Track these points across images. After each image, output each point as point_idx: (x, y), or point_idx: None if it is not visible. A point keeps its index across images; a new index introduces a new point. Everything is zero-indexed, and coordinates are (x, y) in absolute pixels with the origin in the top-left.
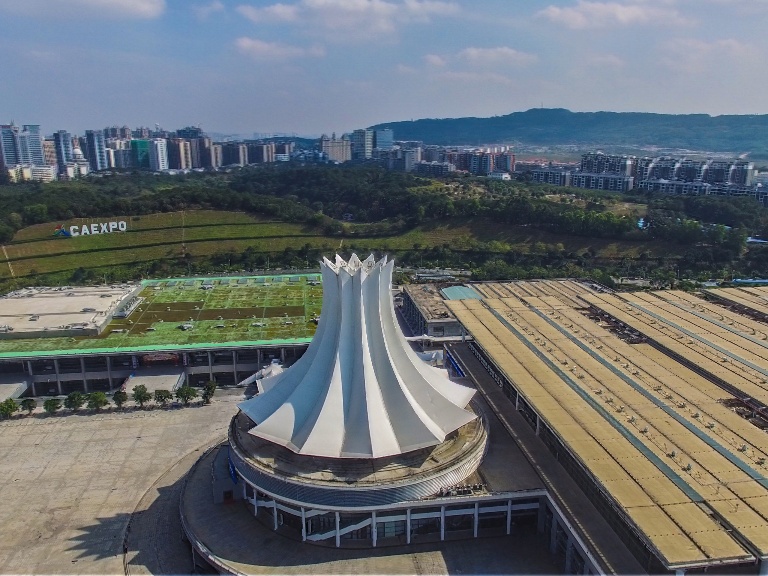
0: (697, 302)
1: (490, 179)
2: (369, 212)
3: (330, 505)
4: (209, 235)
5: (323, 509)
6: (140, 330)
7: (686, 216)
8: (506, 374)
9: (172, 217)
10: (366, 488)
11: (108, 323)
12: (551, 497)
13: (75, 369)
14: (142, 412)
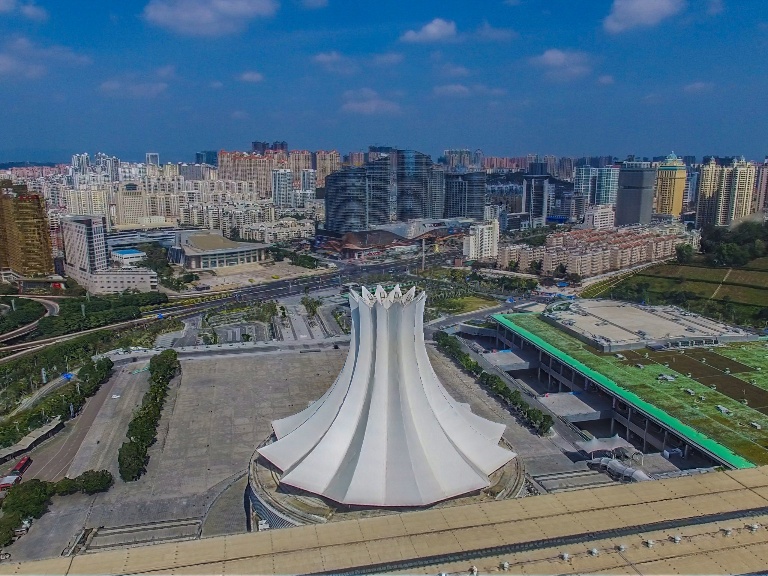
0: None
1: None
2: None
3: None
4: None
5: None
6: (633, 363)
7: None
8: None
9: None
10: None
11: (632, 348)
12: None
13: None
14: (506, 412)
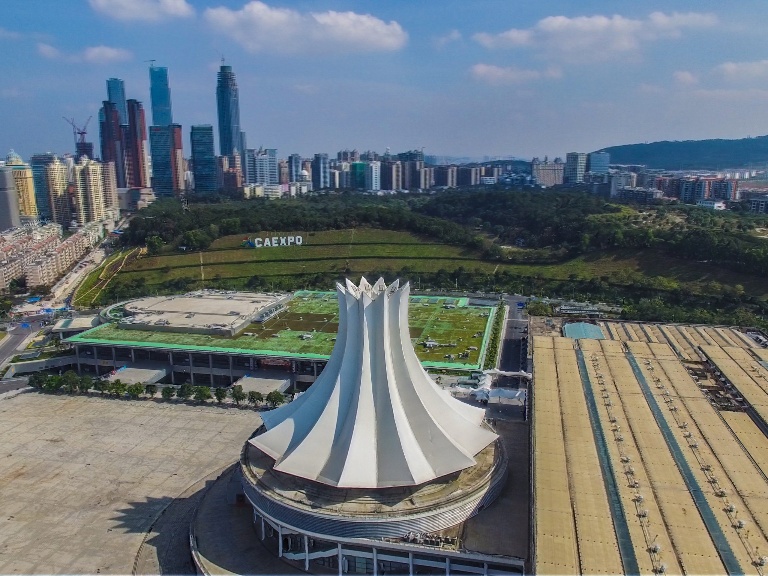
0: None
1: (696, 208)
2: (540, 238)
3: (294, 526)
4: (372, 253)
5: (289, 528)
6: (267, 335)
7: None
8: (533, 423)
9: (343, 234)
10: (326, 516)
11: (245, 326)
12: (524, 569)
13: (207, 364)
14: (236, 410)
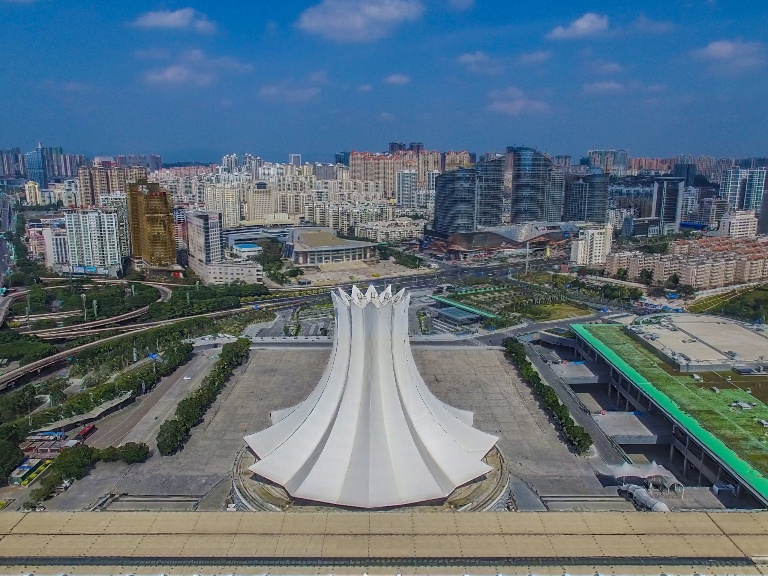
0: None
1: None
2: None
3: None
4: None
5: None
6: (710, 386)
7: None
8: None
9: None
10: None
11: (715, 370)
12: None
13: None
14: (551, 427)
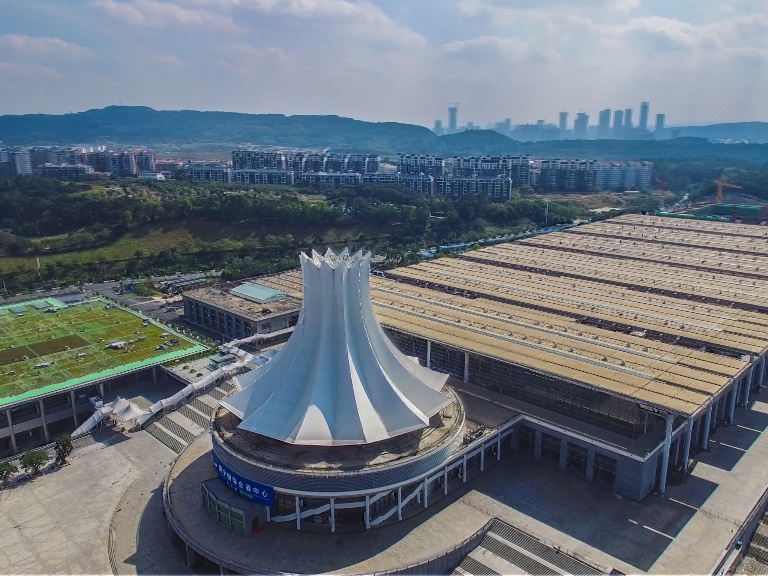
0: (469, 264)
1: (149, 180)
2: (40, 224)
3: (403, 481)
4: None
5: (396, 487)
6: None
7: (380, 201)
8: (435, 338)
9: None
10: (429, 454)
11: None
12: (531, 418)
13: None
14: None
